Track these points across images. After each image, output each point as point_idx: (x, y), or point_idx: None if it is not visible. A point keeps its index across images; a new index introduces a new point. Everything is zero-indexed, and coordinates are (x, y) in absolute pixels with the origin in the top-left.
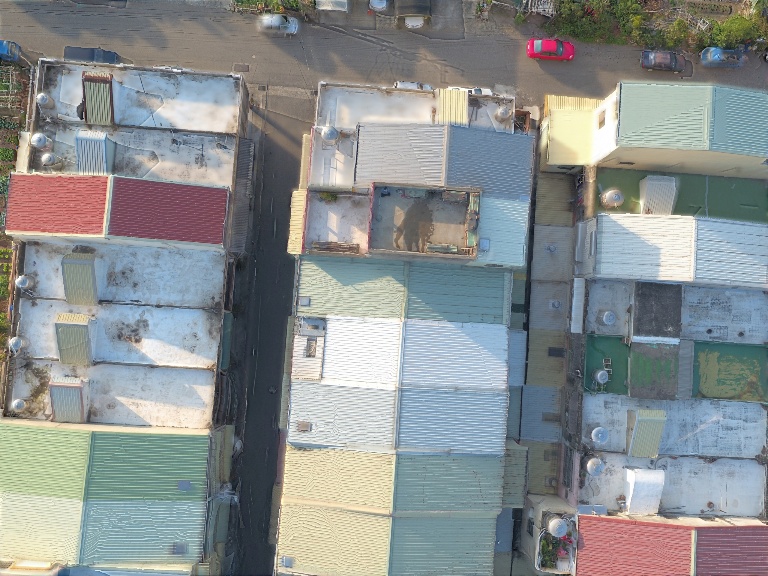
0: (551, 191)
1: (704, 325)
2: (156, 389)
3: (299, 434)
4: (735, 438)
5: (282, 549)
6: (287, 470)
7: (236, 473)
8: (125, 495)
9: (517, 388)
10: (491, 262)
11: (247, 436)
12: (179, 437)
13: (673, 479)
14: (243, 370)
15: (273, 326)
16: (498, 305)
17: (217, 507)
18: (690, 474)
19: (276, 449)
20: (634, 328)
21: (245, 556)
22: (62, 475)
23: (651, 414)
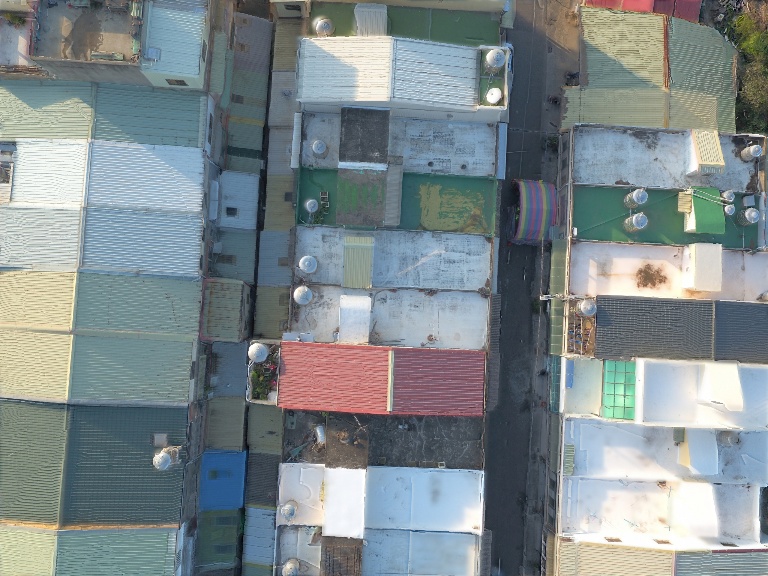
0: (289, 37)
1: (426, 158)
2: None
3: None
4: (458, 271)
5: None
6: None
7: None
8: None
9: (252, 233)
10: (164, 73)
11: None
12: None
13: (393, 312)
14: None
15: None
16: (193, 128)
17: None
18: (410, 307)
19: None
20: (339, 154)
21: None
22: None
23: (358, 241)
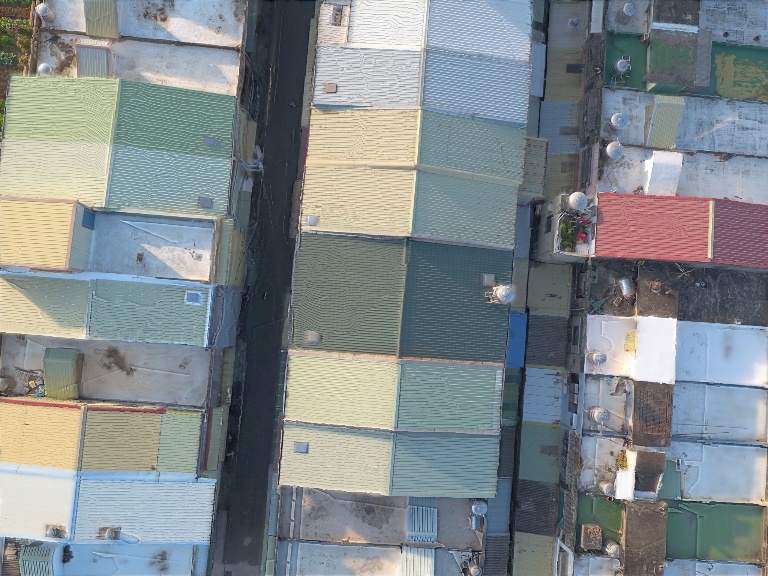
0: None
1: (721, 29)
2: (180, 67)
3: (324, 95)
4: (750, 138)
5: (306, 209)
6: (312, 134)
7: (257, 173)
8: (151, 144)
9: (535, 101)
10: None
11: (267, 148)
12: (205, 94)
13: (689, 175)
14: (264, 83)
15: (294, 44)
16: None
17: (241, 176)
18: (706, 171)
19: (296, 162)
20: (654, 14)
21: (266, 247)
22: (90, 110)
23: (670, 99)
